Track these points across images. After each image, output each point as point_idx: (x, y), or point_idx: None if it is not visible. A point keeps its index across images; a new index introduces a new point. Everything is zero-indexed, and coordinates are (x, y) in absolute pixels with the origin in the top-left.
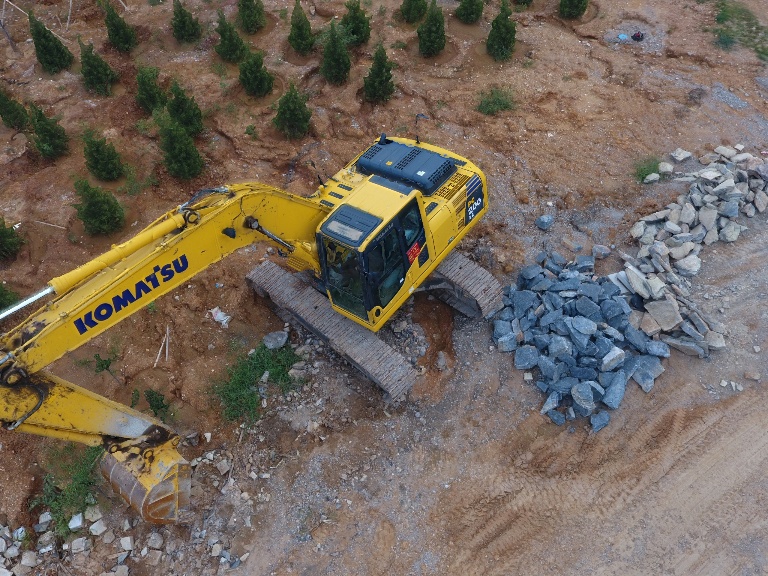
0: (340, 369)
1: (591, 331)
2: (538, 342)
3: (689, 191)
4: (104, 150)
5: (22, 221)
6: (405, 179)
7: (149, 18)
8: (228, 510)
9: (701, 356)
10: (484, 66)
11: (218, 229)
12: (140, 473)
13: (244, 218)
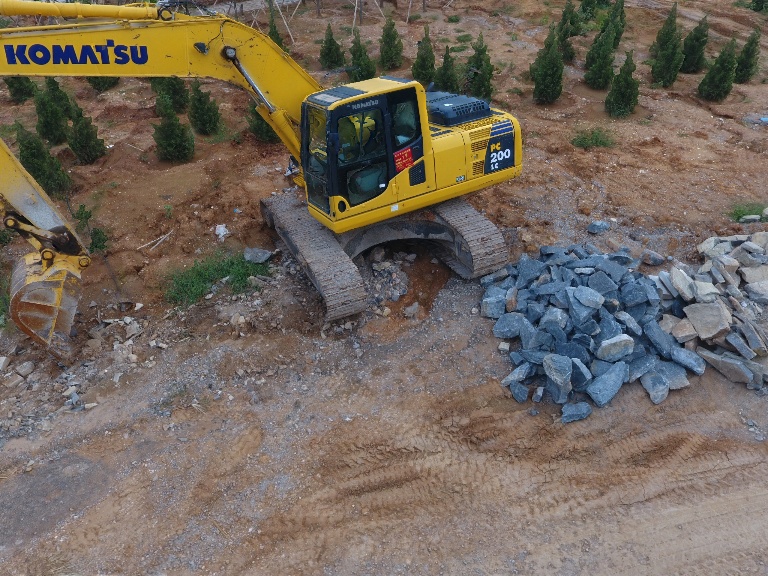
0: (298, 284)
1: (595, 303)
2: (530, 313)
3: None
4: (207, 105)
5: (116, 142)
6: (431, 110)
7: (308, 50)
8: (108, 363)
9: (750, 386)
10: (596, 118)
11: (191, 41)
12: (33, 273)
13: (224, 45)
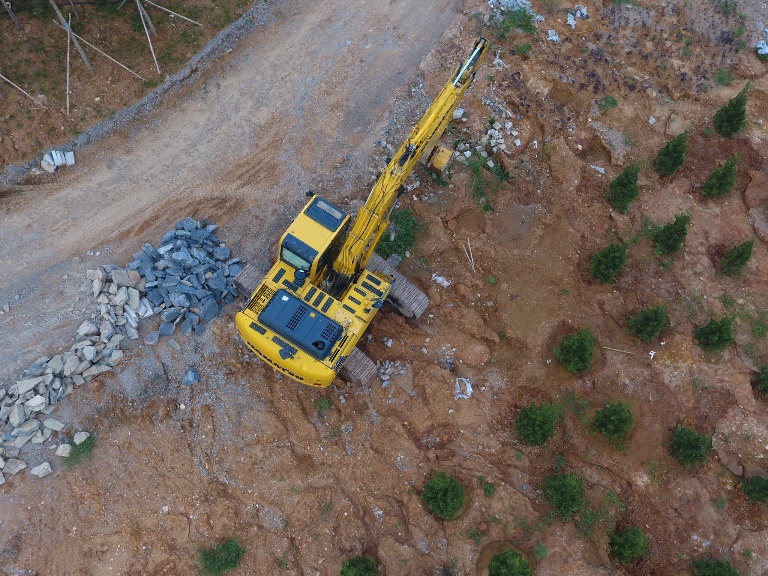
0: None
1: None
2: None
3: (58, 402)
4: None
5: None
6: (299, 299)
7: None
8: None
9: None
10: None
11: None
12: None
13: None
